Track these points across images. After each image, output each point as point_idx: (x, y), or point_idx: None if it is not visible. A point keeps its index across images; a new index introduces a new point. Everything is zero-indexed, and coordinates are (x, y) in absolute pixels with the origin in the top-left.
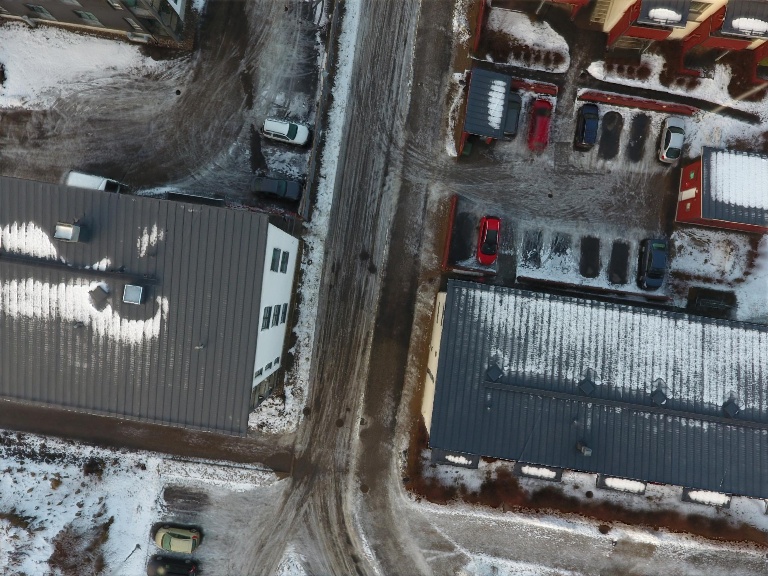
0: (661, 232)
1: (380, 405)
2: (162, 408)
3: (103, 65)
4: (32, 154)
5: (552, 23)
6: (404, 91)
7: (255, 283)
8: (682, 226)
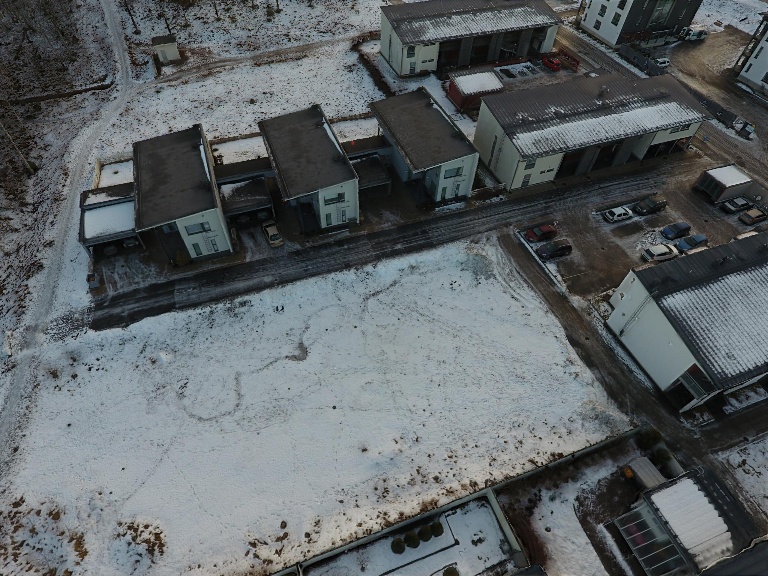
0: None
1: None
2: None
3: None
4: (725, 39)
5: None
6: None
7: None
8: None
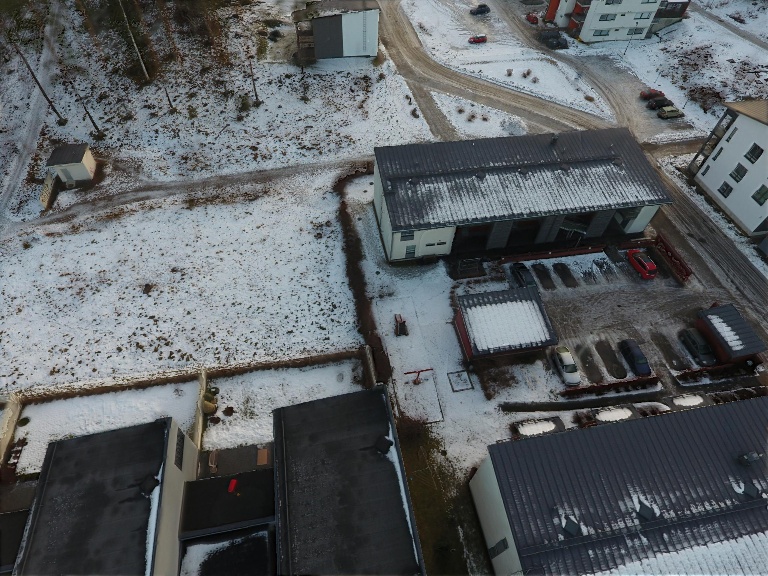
0: None
1: None
2: (767, 102)
3: None
4: None
5: None
6: None
7: None
8: None
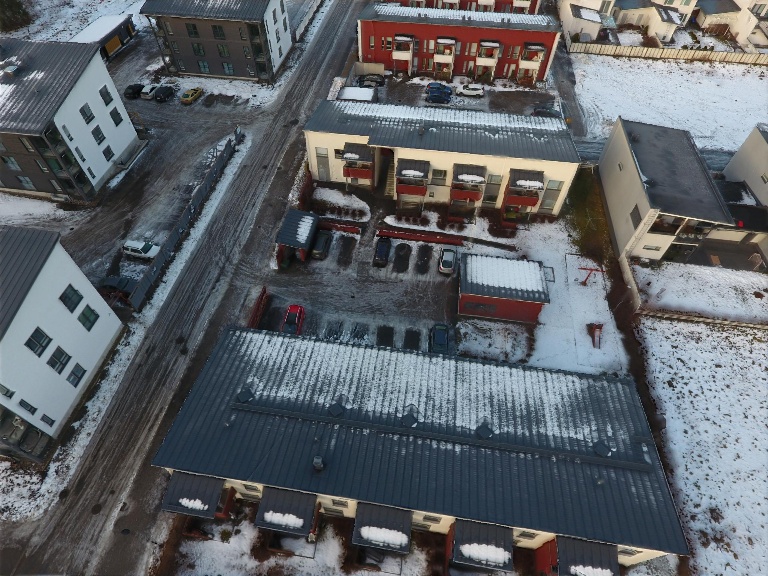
0: (447, 322)
1: (150, 486)
2: None
3: (24, 212)
4: None
5: (358, 195)
6: (246, 231)
7: (27, 281)
8: (465, 318)
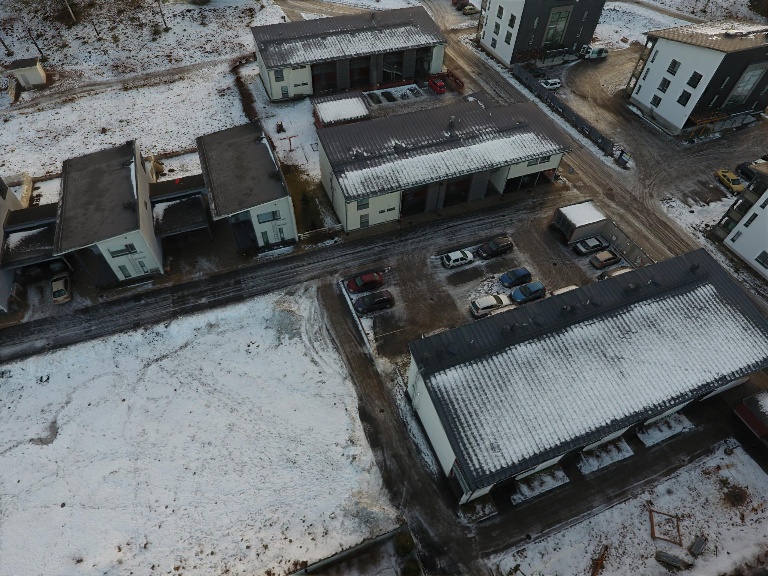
0: None
1: None
2: None
3: None
4: (628, 57)
5: None
6: None
7: None
8: None
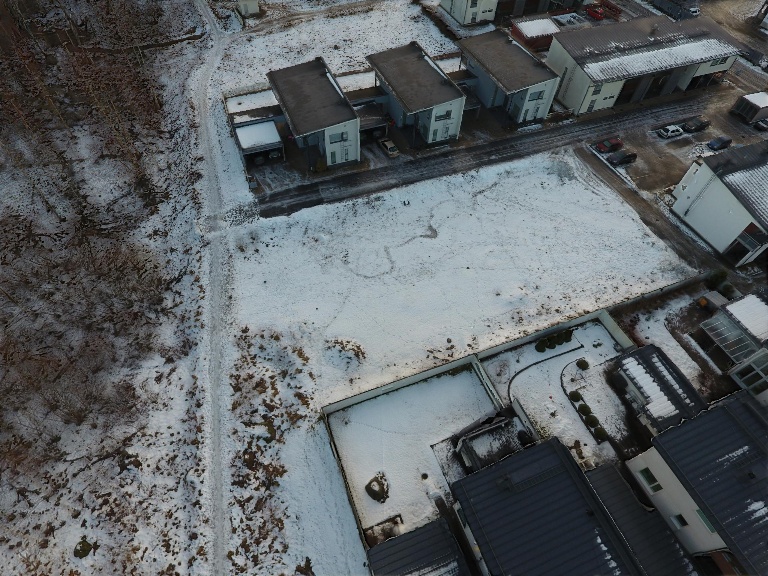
0: None
1: None
2: None
3: None
4: None
5: None
6: None
7: None
8: None
